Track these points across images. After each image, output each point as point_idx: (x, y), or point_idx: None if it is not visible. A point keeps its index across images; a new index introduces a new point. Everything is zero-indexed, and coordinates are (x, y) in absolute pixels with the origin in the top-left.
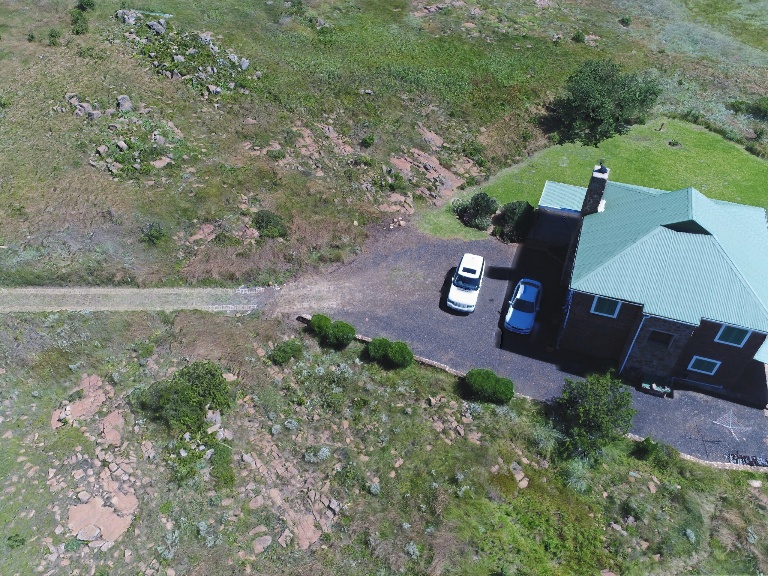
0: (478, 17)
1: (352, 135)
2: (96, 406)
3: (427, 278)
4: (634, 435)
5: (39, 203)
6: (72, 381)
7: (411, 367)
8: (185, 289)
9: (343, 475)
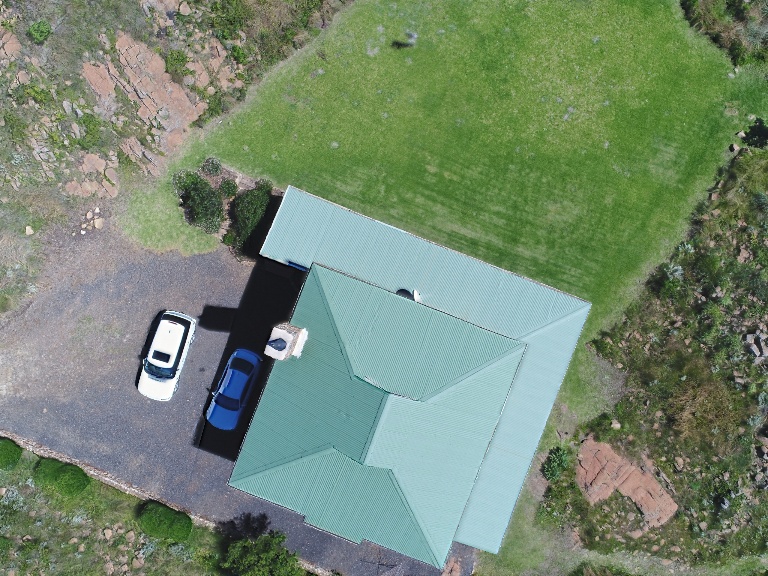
0: None
1: (18, 1)
2: None
3: (125, 333)
4: (309, 566)
5: None
6: None
7: (90, 485)
8: None
9: None
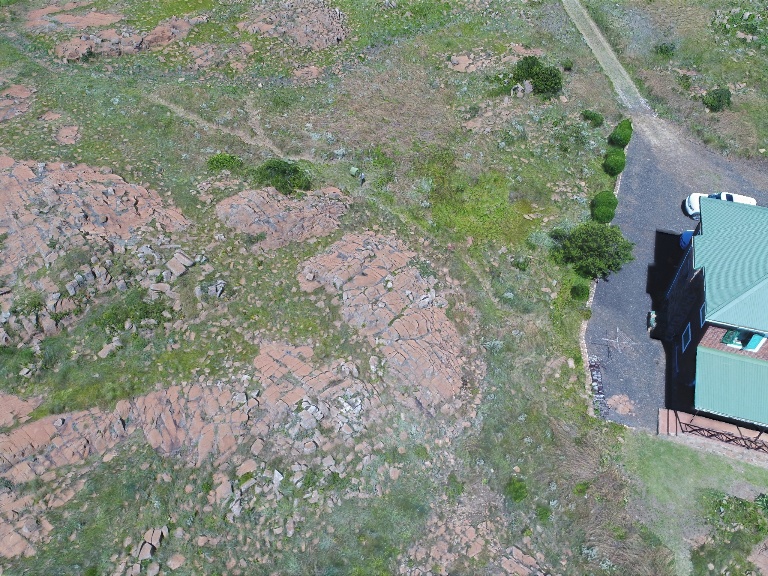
0: None
1: None
2: (522, 54)
3: None
4: None
5: (663, 6)
6: (535, 46)
7: (610, 178)
8: (628, 76)
9: (507, 133)
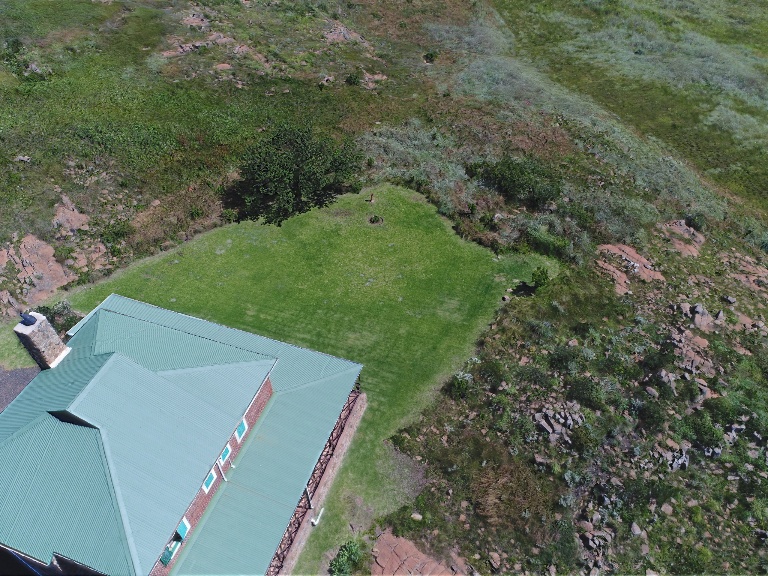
0: (240, 57)
1: None
2: None
3: None
4: None
5: None
6: None
7: None
8: None
9: None
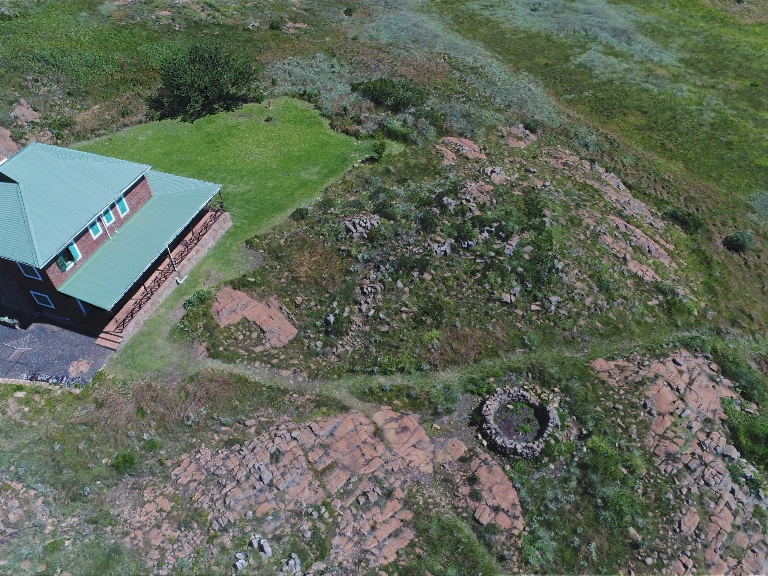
0: (179, 6)
1: None
2: None
3: None
4: None
5: None
6: None
7: None
8: None
9: None
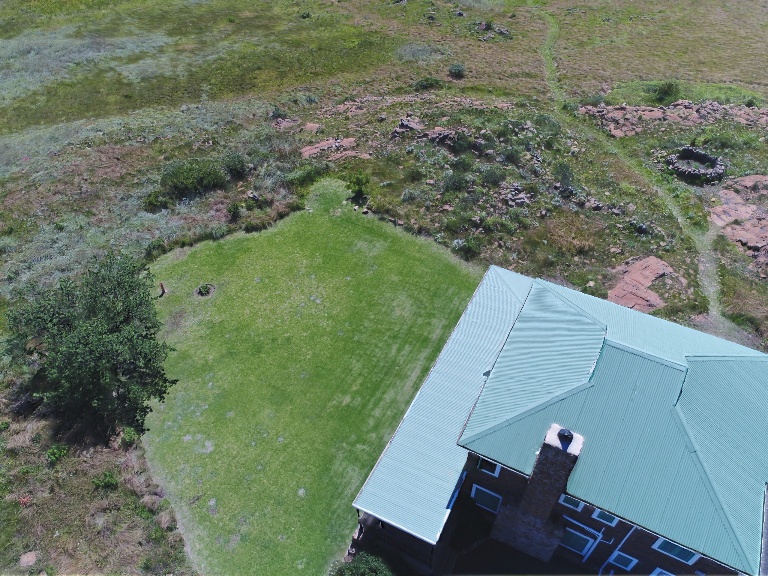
0: None
1: None
2: None
3: None
4: None
5: None
6: None
7: None
8: None
9: None
